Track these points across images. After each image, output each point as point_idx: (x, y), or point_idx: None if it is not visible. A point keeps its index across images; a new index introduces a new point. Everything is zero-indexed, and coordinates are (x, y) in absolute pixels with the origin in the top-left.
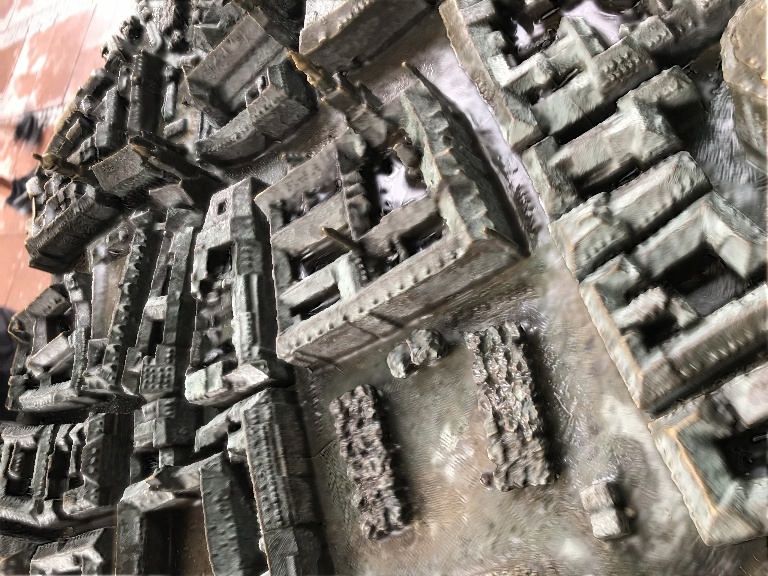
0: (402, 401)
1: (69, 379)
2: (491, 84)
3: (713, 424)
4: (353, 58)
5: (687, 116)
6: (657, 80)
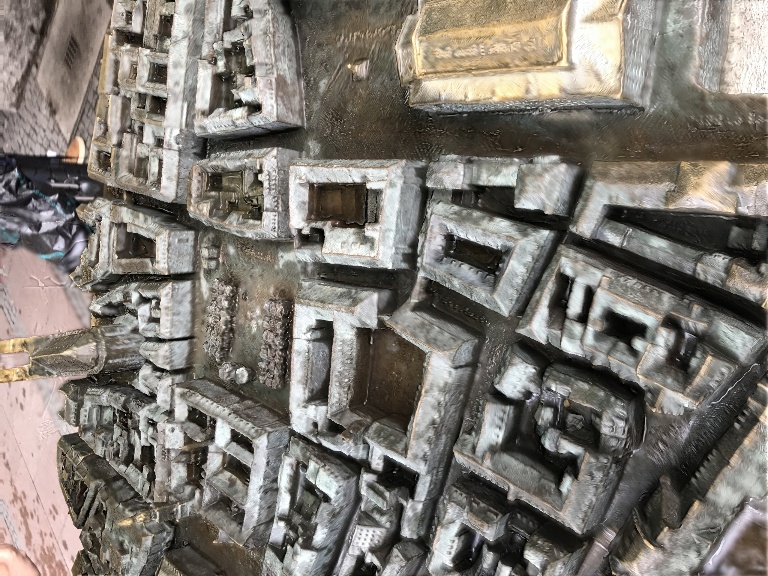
0: None
1: None
2: (158, 449)
3: None
4: (216, 575)
5: None
6: (133, 385)
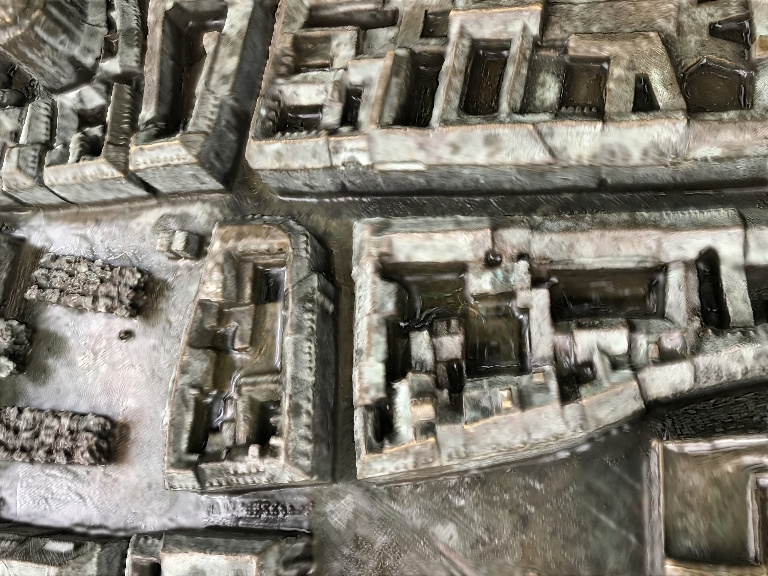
0: (37, 393)
1: None
2: None
3: (146, 131)
4: None
5: (26, 104)
6: None
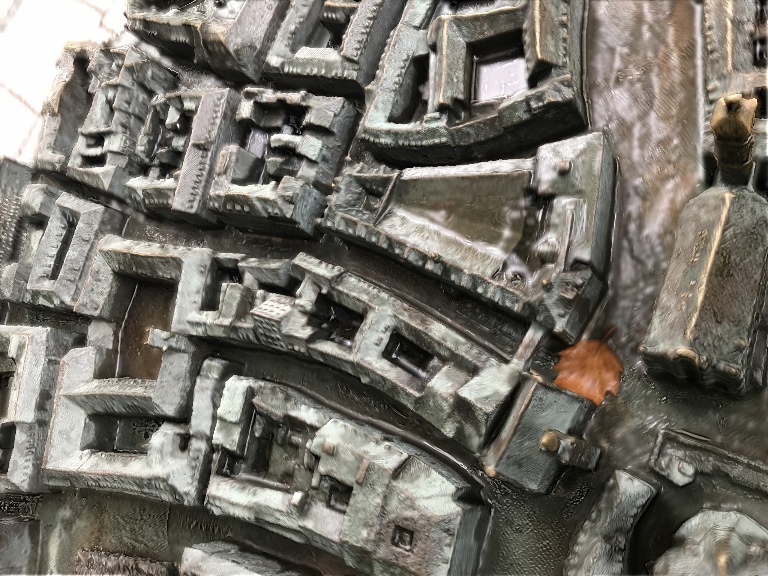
0: None
1: (426, 80)
2: None
3: None
4: None
5: None
6: None
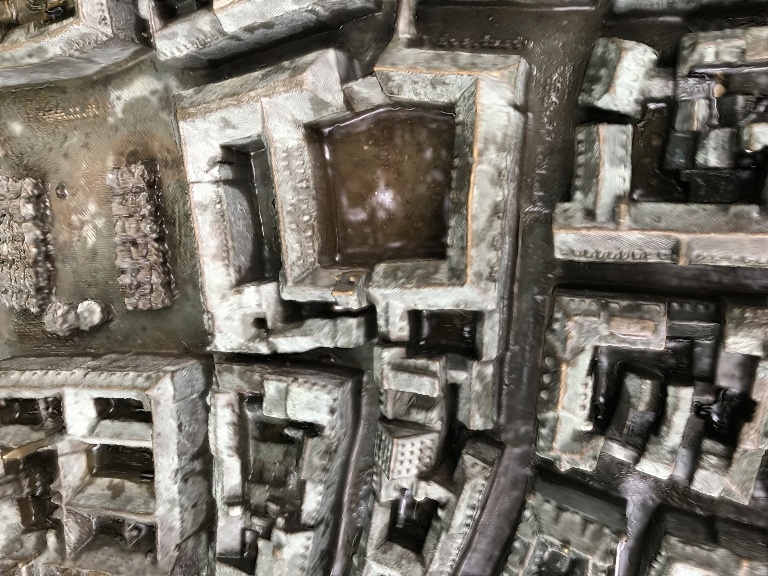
0: None
1: None
2: None
3: None
4: None
5: None
6: None
